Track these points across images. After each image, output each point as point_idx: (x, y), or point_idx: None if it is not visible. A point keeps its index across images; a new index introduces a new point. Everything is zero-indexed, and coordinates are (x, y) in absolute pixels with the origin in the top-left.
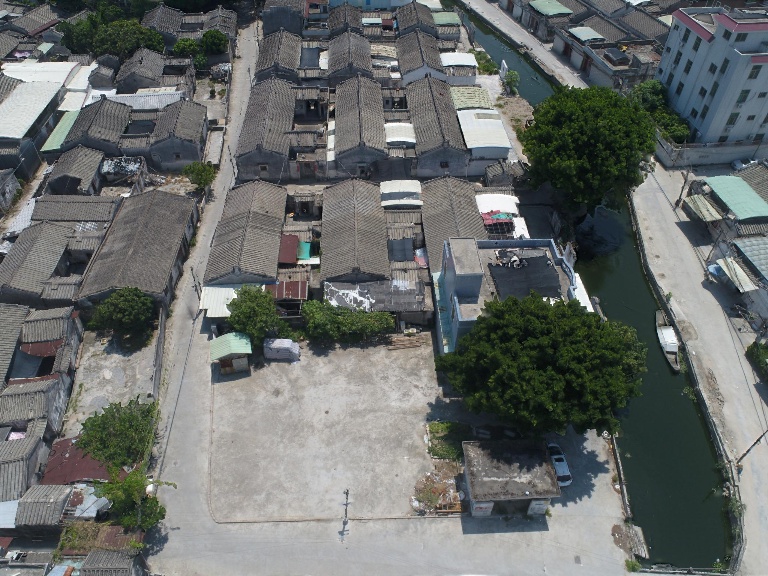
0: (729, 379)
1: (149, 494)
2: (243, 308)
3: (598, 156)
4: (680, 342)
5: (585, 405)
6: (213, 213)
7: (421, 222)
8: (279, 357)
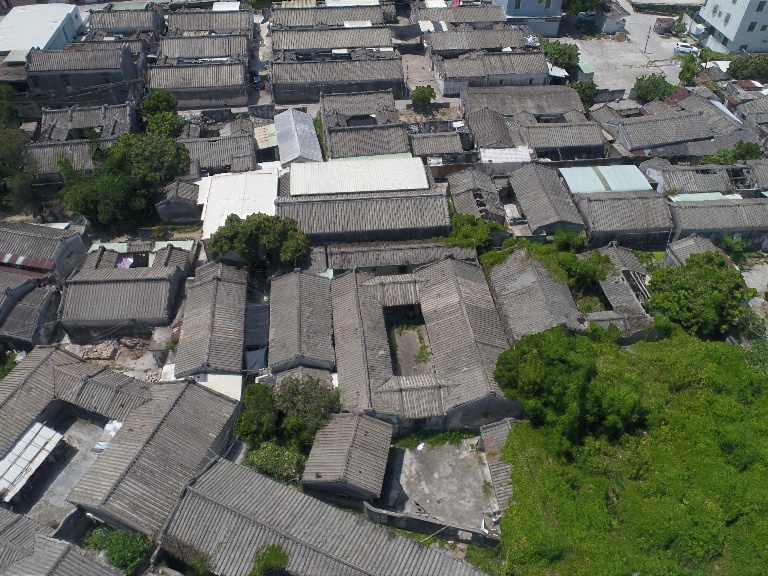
0: None
1: None
2: None
3: None
4: None
5: None
6: None
7: (455, 26)
8: None
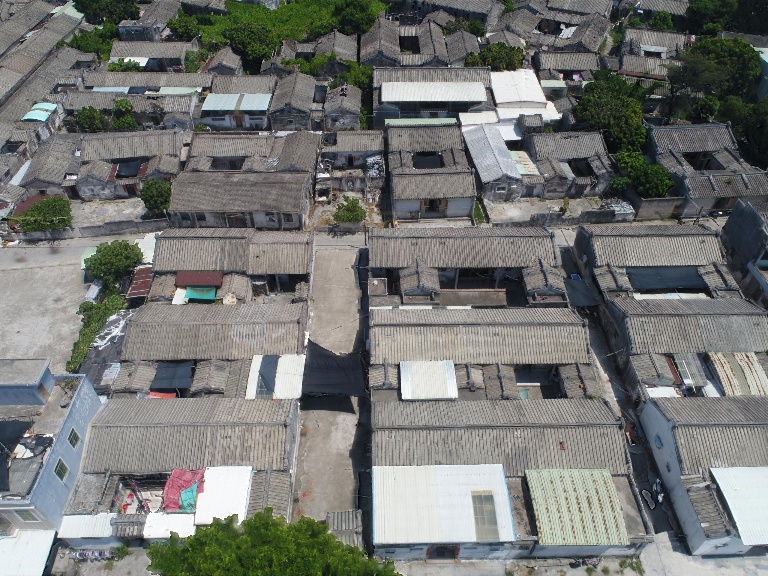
0: None
1: (8, 244)
2: (100, 244)
3: None
4: None
5: None
6: None
7: None
8: None
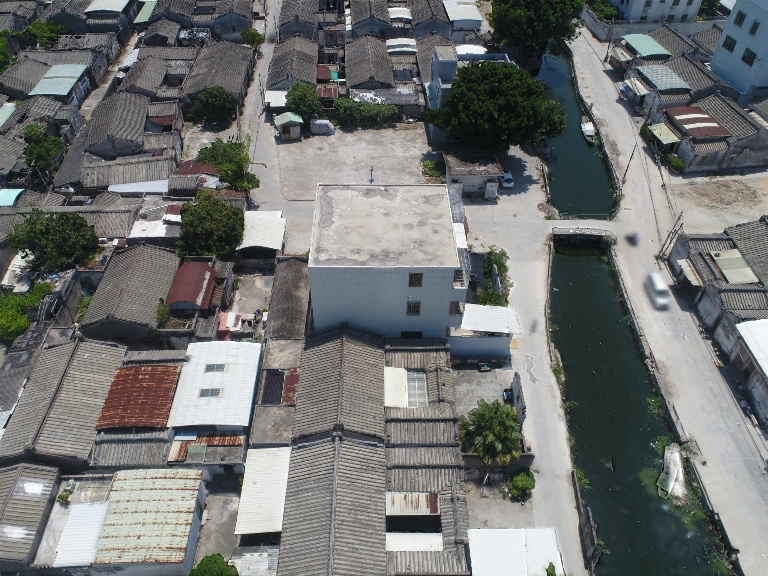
0: (626, 145)
1: None
2: (297, 92)
3: (541, 8)
4: (596, 130)
5: (518, 117)
6: (264, 64)
7: (416, 62)
8: (320, 132)
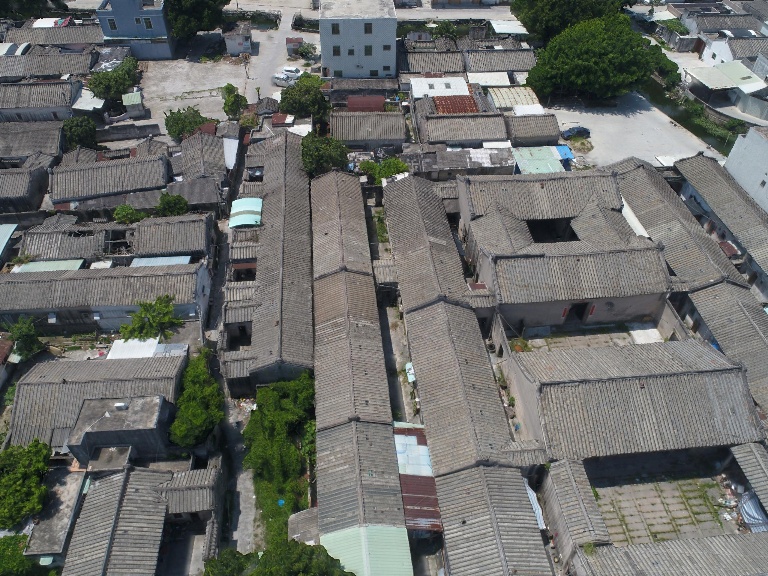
0: None
1: None
2: (113, 75)
3: None
4: None
5: None
6: None
7: None
8: None
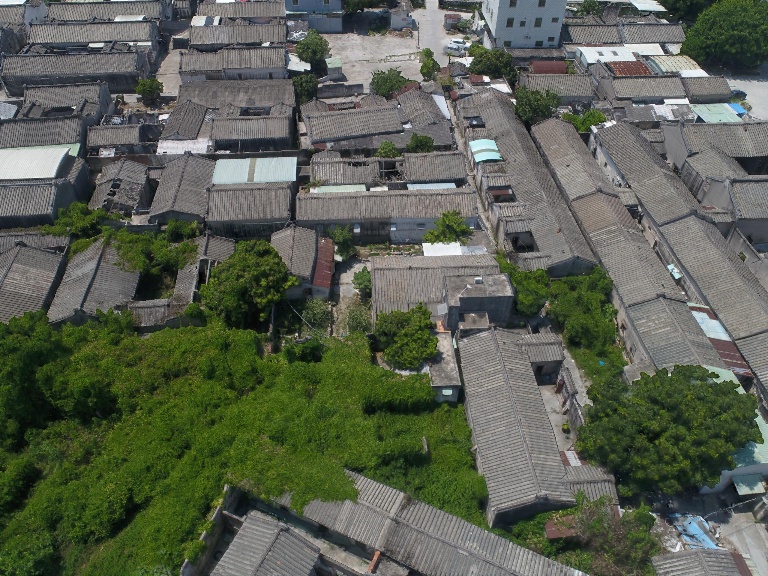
0: None
1: None
2: (319, 41)
3: None
4: None
5: None
6: None
7: None
8: None
